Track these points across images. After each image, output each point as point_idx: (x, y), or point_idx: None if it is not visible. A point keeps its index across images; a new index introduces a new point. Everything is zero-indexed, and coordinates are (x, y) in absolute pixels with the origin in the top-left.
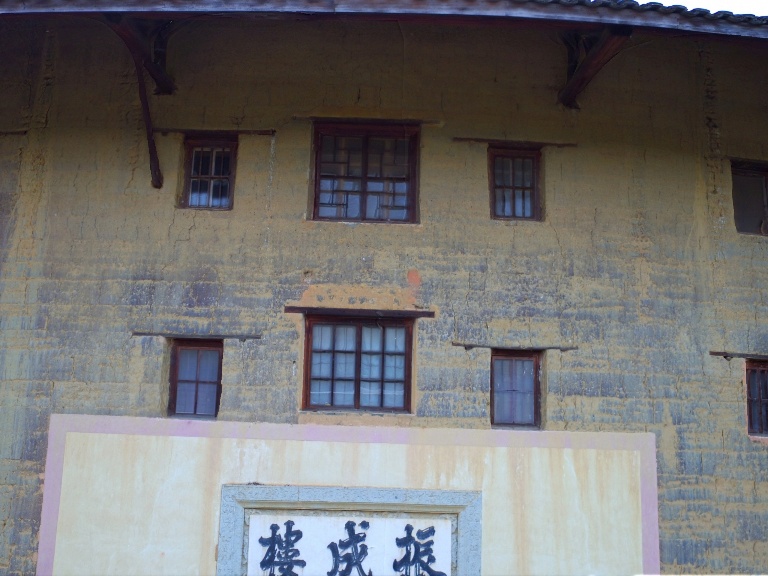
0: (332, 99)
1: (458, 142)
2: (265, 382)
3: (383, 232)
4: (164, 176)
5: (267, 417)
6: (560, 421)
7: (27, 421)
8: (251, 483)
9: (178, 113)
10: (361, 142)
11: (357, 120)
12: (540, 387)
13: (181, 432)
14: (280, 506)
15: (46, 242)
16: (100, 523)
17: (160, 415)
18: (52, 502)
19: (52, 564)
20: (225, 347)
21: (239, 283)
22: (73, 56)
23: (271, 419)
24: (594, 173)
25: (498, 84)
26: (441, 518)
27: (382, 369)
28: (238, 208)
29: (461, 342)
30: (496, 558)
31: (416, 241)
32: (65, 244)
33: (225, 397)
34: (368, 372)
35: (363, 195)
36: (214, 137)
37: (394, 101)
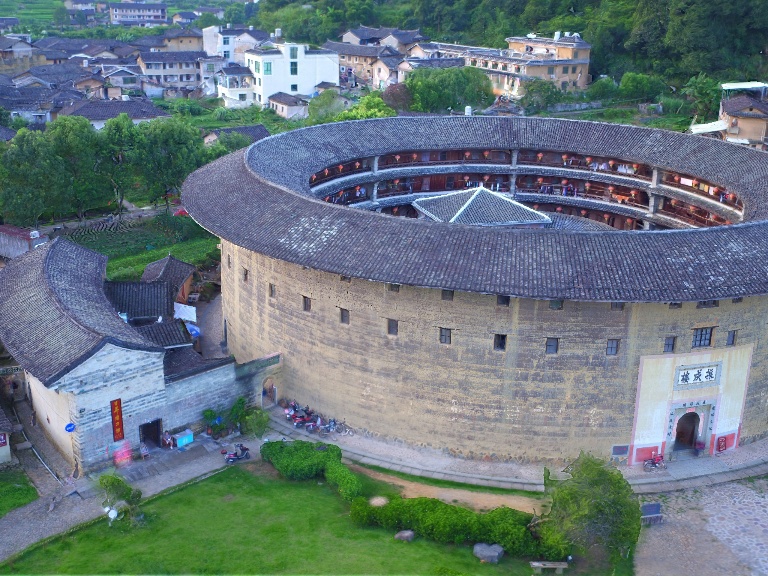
0: None
1: None
2: None
3: None
4: None
5: None
6: None
7: None
8: (682, 366)
9: None
10: None
11: None
12: None
13: (668, 357)
14: None
15: (640, 318)
16: (651, 377)
17: (664, 354)
18: None
19: None
20: None
21: None
22: None
23: (686, 352)
24: None
25: None
26: None
27: None
28: (683, 308)
29: None
30: None
31: None
32: None
33: None
34: None
35: None
36: None
37: None
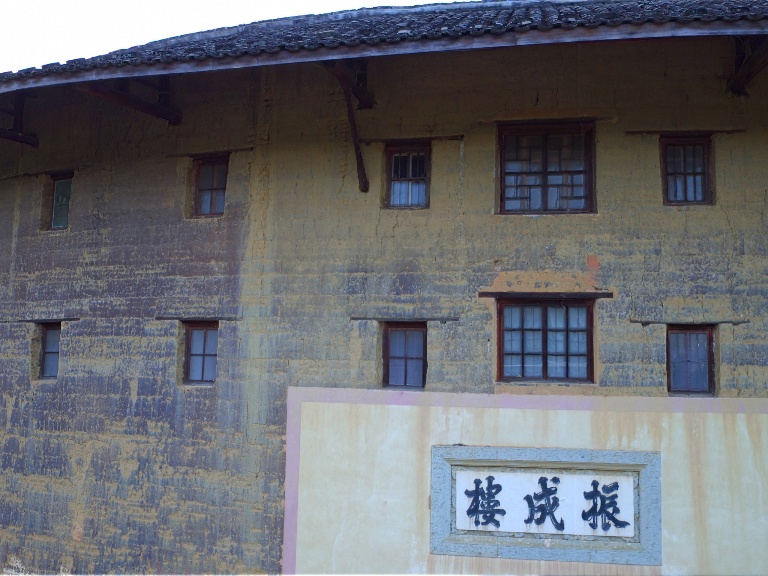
0: (513, 103)
1: (631, 135)
2: (464, 358)
3: (564, 222)
4: (369, 181)
5: (467, 388)
6: (733, 389)
7: (269, 393)
8: (456, 444)
9: (378, 125)
10: (541, 140)
11: (537, 121)
12: (714, 358)
13: (395, 401)
14: (482, 464)
15: (275, 243)
16: (333, 476)
17: (377, 387)
18: (293, 459)
19: (297, 509)
20: (429, 328)
21: (438, 273)
22: (287, 80)
23: (471, 390)
24: (764, 156)
25: (668, 78)
26: (624, 475)
27: (567, 344)
28: (434, 207)
29: (638, 319)
30: (675, 510)
31: (594, 229)
32: (291, 244)
33: (431, 371)
34: (554, 347)
35: (544, 188)
36: (410, 144)
37: (570, 101)
